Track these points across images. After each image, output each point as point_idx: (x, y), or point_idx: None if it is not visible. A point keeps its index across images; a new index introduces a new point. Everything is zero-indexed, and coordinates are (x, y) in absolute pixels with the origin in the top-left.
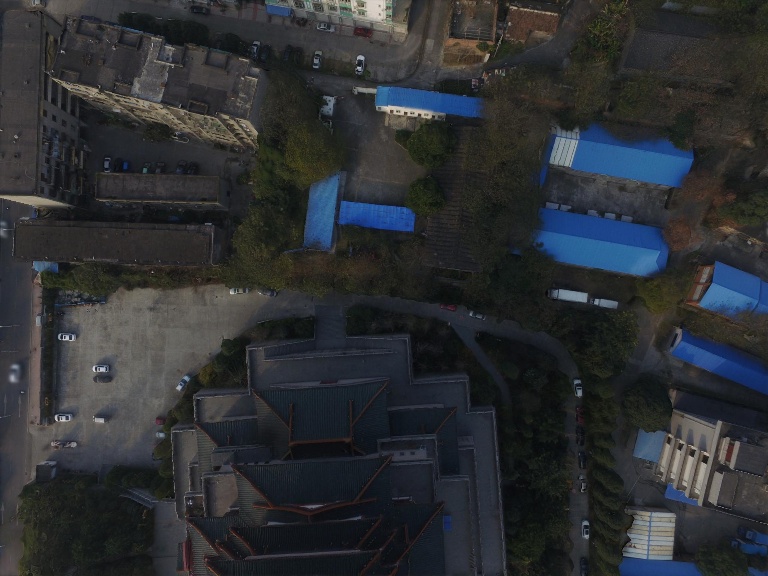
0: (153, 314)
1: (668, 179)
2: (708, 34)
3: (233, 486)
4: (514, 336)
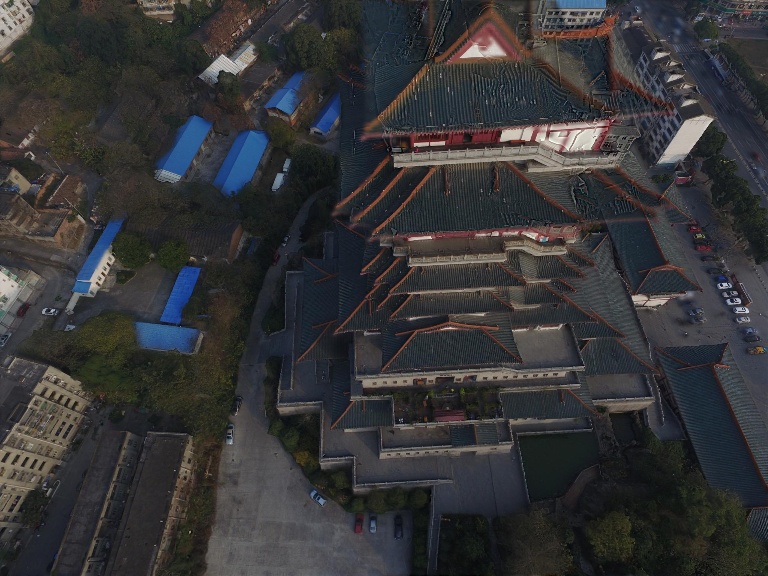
0: (239, 537)
1: (205, 129)
2: (115, 105)
3: (367, 352)
4: None
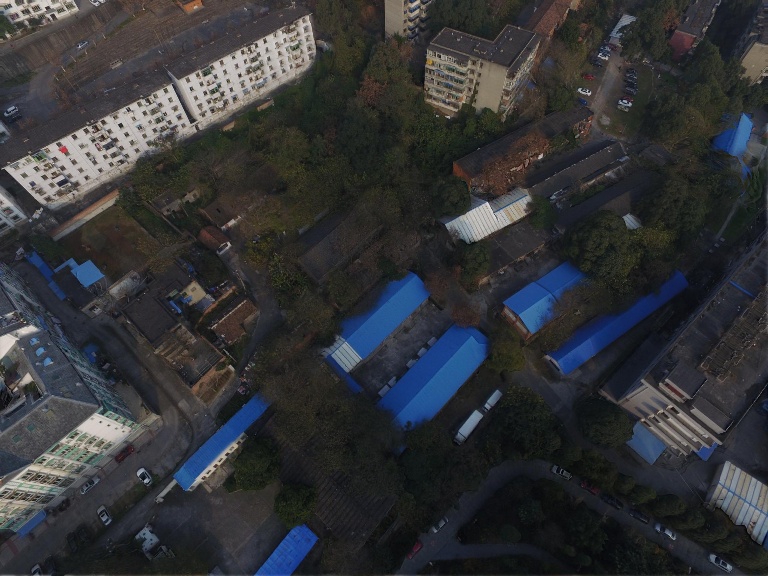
0: None
1: (420, 298)
2: (338, 222)
3: None
4: (480, 501)
